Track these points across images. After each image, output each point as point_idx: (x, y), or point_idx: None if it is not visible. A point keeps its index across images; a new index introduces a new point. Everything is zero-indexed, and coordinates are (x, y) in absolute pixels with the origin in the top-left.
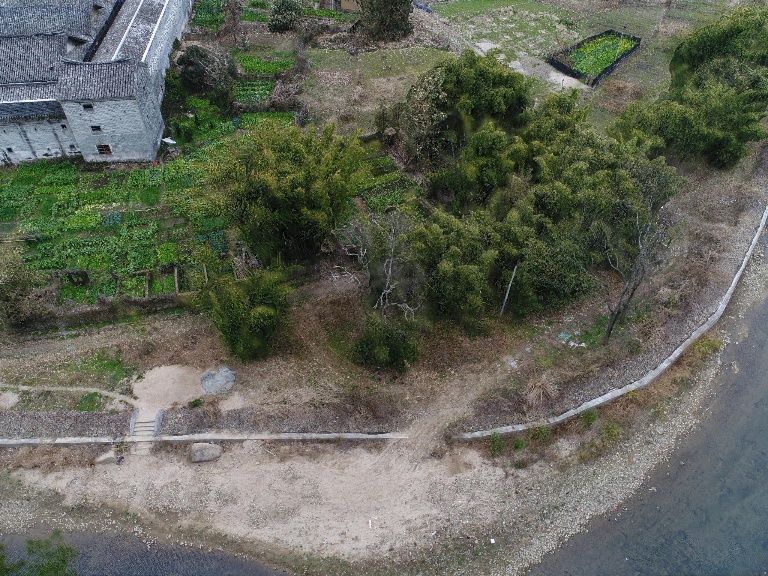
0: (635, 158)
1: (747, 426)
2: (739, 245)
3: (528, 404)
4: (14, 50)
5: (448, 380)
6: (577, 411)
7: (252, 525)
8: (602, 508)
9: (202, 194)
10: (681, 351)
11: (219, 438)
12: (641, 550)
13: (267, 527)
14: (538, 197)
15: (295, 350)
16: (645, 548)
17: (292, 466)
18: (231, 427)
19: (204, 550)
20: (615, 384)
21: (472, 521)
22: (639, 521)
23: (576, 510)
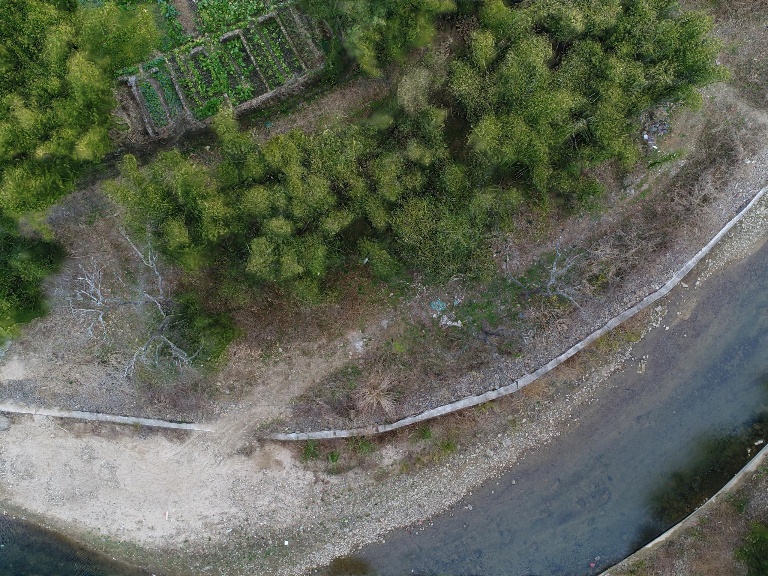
0: (664, 2)
1: (612, 444)
2: (767, 165)
3: (358, 410)
4: None
5: (272, 362)
6: (415, 420)
7: (51, 501)
8: (407, 521)
9: None
10: (579, 349)
11: (4, 410)
12: (430, 564)
13: (65, 507)
14: (451, 95)
15: (83, 303)
16: (435, 563)
17: (89, 444)
18: (16, 398)
19: (8, 516)
20: (474, 390)
21: (270, 523)
22: (440, 537)
23: (379, 521)
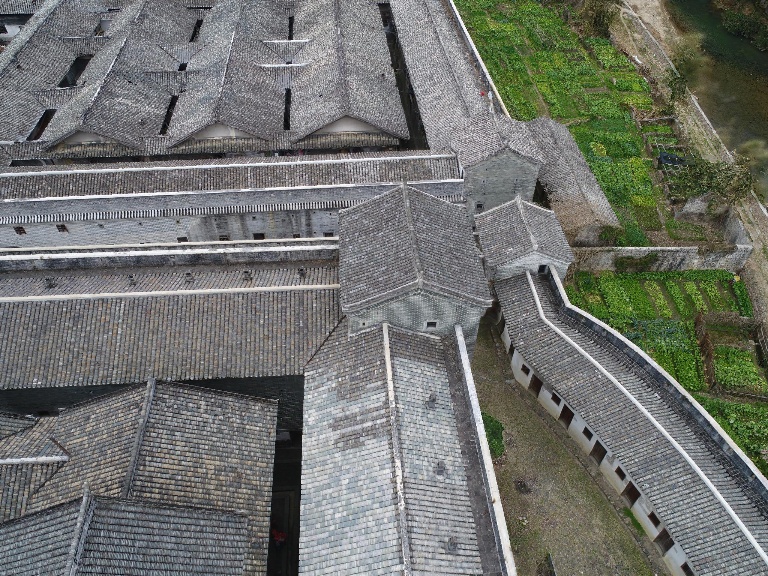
0: None
1: None
2: None
3: None
4: (350, 7)
5: None
6: None
7: (653, 1)
8: None
9: (472, 2)
10: None
11: None
12: None
13: None
14: None
15: None
16: None
17: None
18: None
19: None
20: None
21: None
22: None
23: None
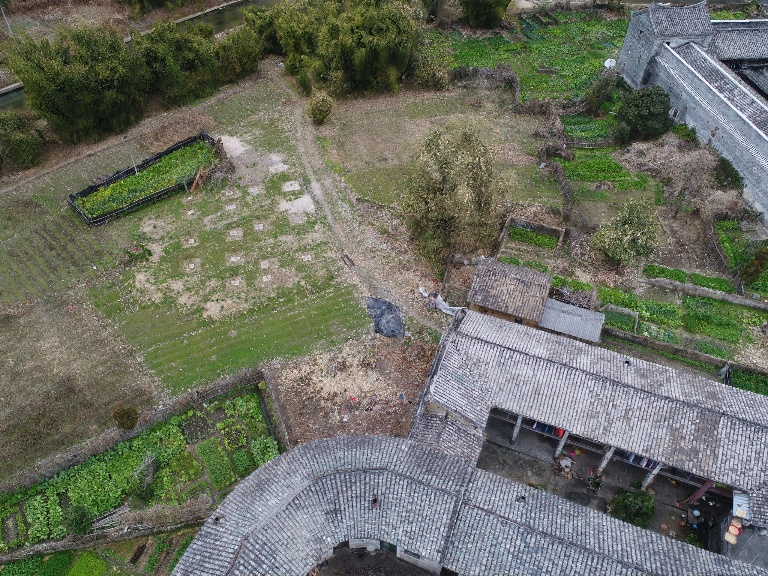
0: None
1: None
2: None
3: None
4: None
5: None
6: None
7: None
8: None
9: None
10: None
11: None
12: None
13: None
14: None
15: None
16: None
17: None
18: None
19: None
20: None
21: None
22: None
23: None
